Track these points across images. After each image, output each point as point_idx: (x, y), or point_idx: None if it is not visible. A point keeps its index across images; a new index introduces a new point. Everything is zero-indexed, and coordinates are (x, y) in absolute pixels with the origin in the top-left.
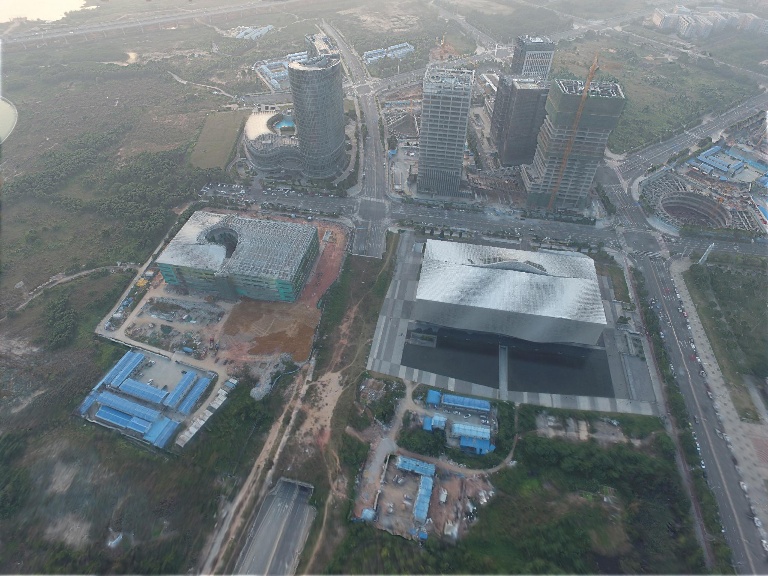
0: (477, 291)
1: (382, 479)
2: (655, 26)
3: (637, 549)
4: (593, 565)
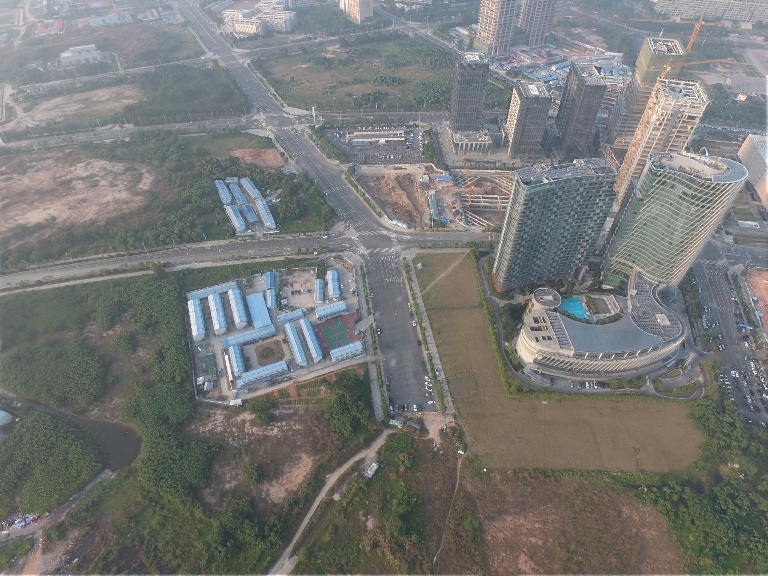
0: None
1: None
2: (256, 35)
3: None
4: None
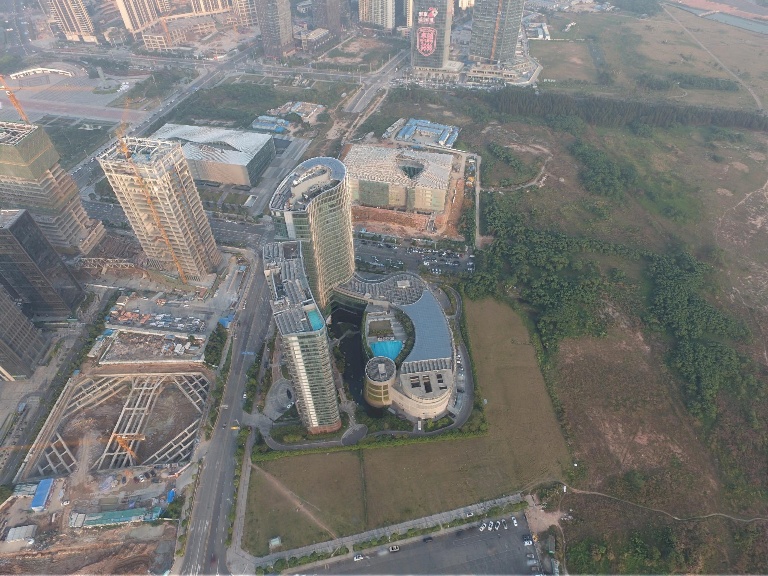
0: (231, 134)
1: (312, 112)
2: None
3: None
4: (241, 98)
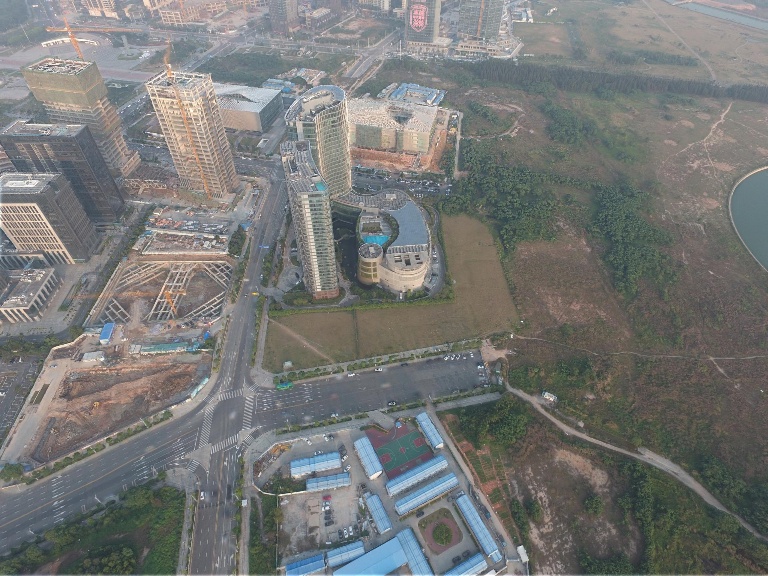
0: None
1: None
2: None
3: (234, 66)
4: None
